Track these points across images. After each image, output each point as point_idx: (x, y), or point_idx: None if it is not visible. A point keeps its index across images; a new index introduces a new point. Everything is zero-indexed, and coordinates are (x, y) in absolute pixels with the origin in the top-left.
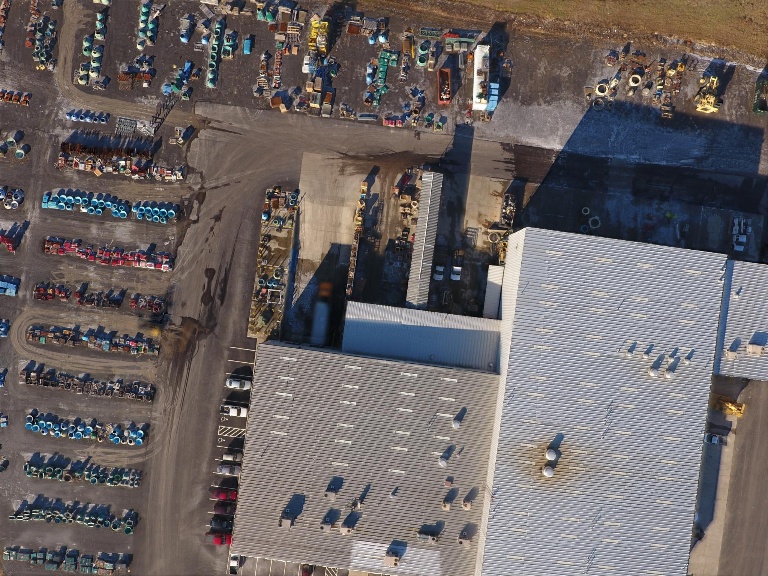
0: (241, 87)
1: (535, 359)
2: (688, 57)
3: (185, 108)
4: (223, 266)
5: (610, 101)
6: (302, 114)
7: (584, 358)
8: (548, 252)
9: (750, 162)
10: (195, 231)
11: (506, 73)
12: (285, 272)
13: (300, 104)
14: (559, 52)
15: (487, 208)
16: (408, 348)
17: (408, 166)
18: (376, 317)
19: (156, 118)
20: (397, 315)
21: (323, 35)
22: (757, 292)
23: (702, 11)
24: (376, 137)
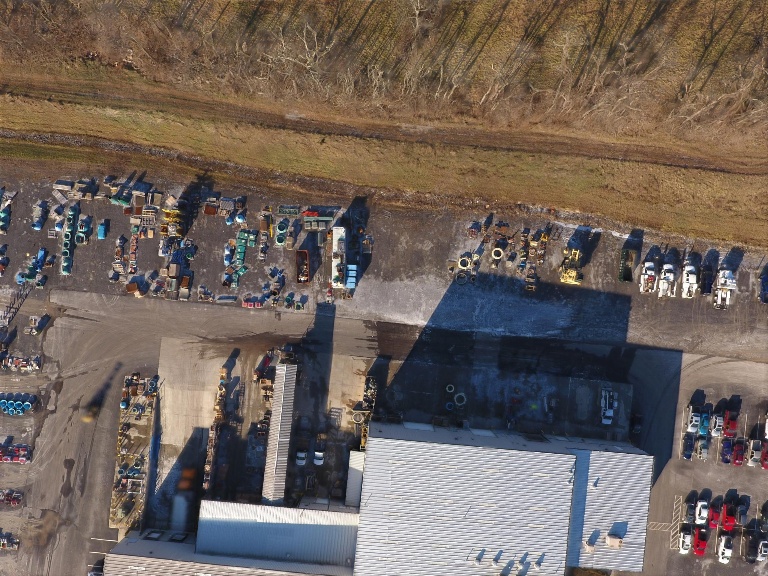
0: (97, 273)
1: (380, 572)
2: (552, 226)
3: (40, 297)
4: (82, 456)
5: (473, 275)
6: (160, 298)
7: (431, 568)
8: (391, 462)
9: (618, 331)
10: (53, 421)
11: (366, 250)
12: (146, 460)
13: (157, 288)
14: (420, 226)
15: (351, 387)
16: (264, 546)
17: (269, 347)
18: (230, 516)
19: (10, 308)
20: (252, 513)
21: (173, 225)
22: (615, 482)
23: (563, 181)
24: (236, 319)
